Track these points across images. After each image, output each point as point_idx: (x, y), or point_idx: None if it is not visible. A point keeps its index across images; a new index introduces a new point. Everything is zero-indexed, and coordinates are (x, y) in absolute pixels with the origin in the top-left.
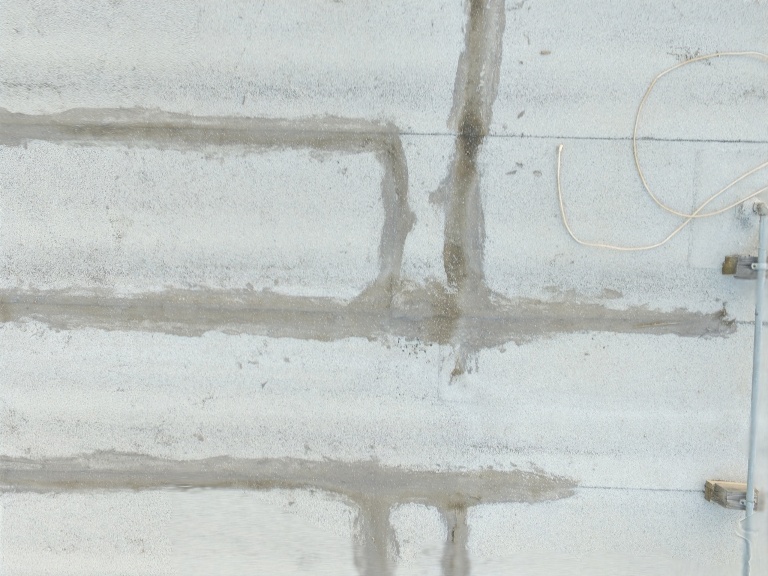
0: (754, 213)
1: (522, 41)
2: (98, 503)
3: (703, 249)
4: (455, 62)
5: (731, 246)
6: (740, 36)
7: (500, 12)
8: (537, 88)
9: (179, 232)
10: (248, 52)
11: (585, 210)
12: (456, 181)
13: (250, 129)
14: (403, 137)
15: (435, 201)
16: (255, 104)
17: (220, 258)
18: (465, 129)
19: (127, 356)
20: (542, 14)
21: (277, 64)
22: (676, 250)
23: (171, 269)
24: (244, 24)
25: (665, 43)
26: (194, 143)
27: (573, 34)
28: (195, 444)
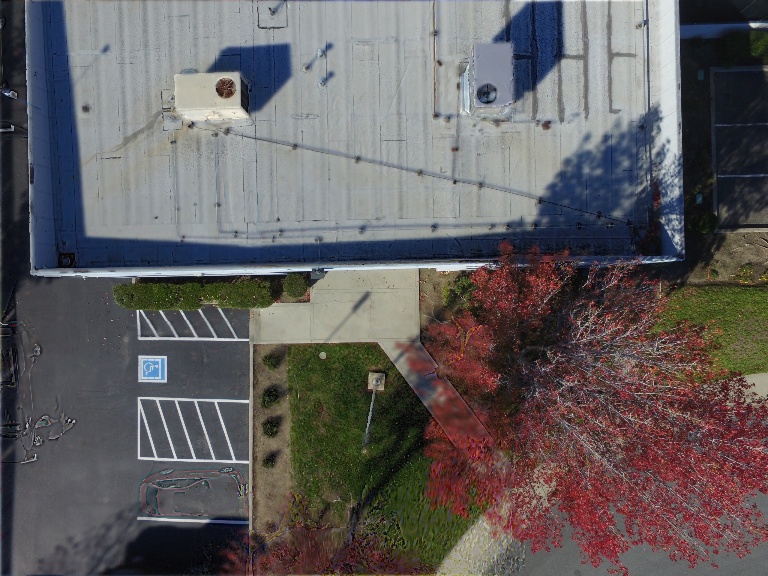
0: None
1: None
2: (589, 19)
3: None
4: None
5: None
6: None
7: None
8: None
9: (547, 7)
10: None
11: None
12: None
13: None
14: None
15: None
16: None
17: (551, 1)
18: None
19: (566, 15)
20: None
21: None
22: None
23: (553, 8)
24: None
25: None
26: (535, 5)
27: None
28: (579, 5)
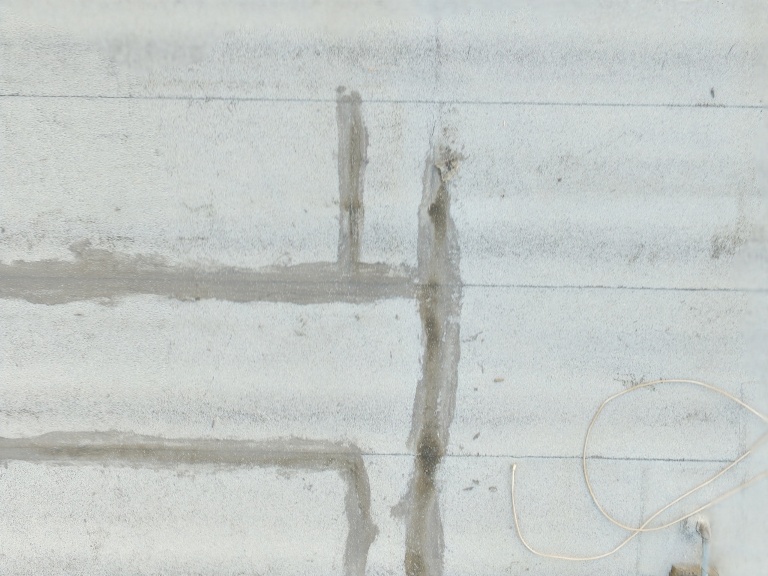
0: (697, 533)
1: (476, 370)
2: None
3: (651, 558)
4: (413, 390)
5: (677, 557)
6: (682, 366)
7: (455, 344)
8: (491, 412)
9: (153, 543)
10: (216, 381)
11: (539, 522)
12: (416, 497)
13: (219, 450)
14: (365, 456)
15: (396, 514)
16: (224, 427)
17: (193, 566)
18: (423, 450)
19: None
20: (495, 345)
21: (244, 391)
22: (625, 559)
23: None
24: (212, 356)
25: (612, 370)
26: (166, 462)
27: (524, 364)
28: None
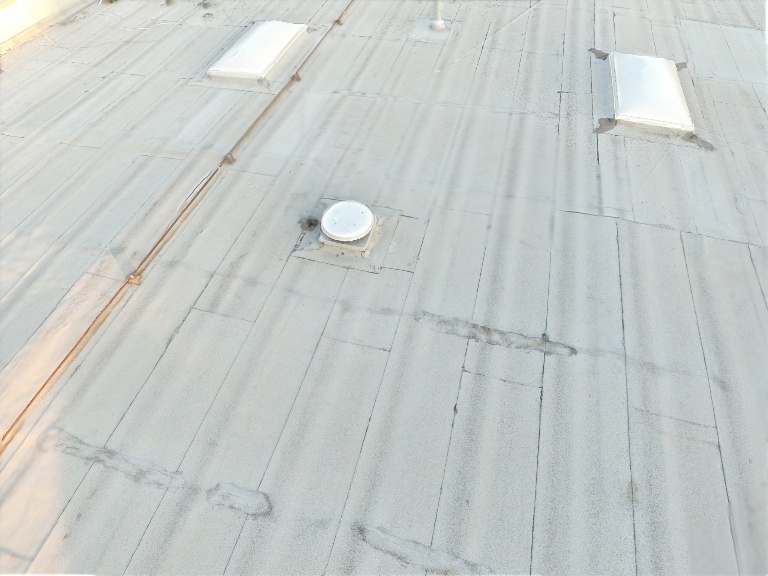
0: None
1: None
2: None
3: None
4: None
5: None
6: (244, 7)
7: None
8: None
9: None
10: None
11: None
12: None
13: None
14: None
15: None
16: None
17: None
18: None
19: None
20: None
21: None
22: None
23: None
24: None
25: None
26: None
27: None
28: None
